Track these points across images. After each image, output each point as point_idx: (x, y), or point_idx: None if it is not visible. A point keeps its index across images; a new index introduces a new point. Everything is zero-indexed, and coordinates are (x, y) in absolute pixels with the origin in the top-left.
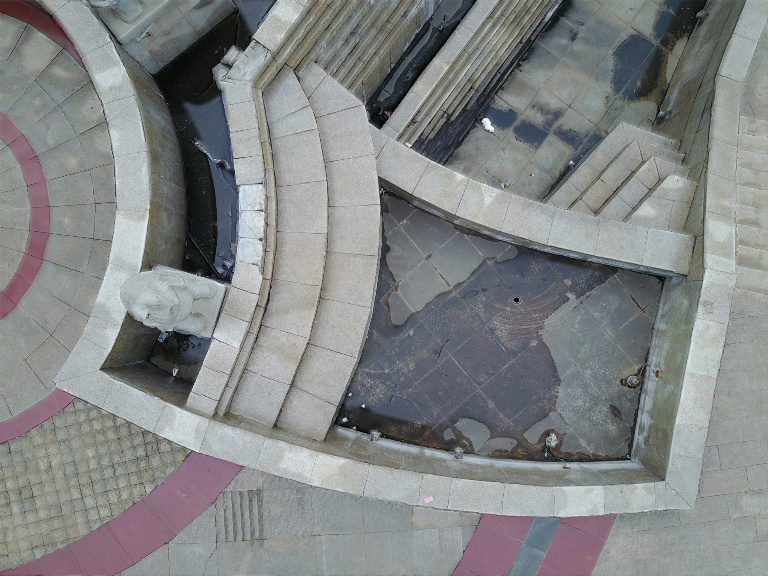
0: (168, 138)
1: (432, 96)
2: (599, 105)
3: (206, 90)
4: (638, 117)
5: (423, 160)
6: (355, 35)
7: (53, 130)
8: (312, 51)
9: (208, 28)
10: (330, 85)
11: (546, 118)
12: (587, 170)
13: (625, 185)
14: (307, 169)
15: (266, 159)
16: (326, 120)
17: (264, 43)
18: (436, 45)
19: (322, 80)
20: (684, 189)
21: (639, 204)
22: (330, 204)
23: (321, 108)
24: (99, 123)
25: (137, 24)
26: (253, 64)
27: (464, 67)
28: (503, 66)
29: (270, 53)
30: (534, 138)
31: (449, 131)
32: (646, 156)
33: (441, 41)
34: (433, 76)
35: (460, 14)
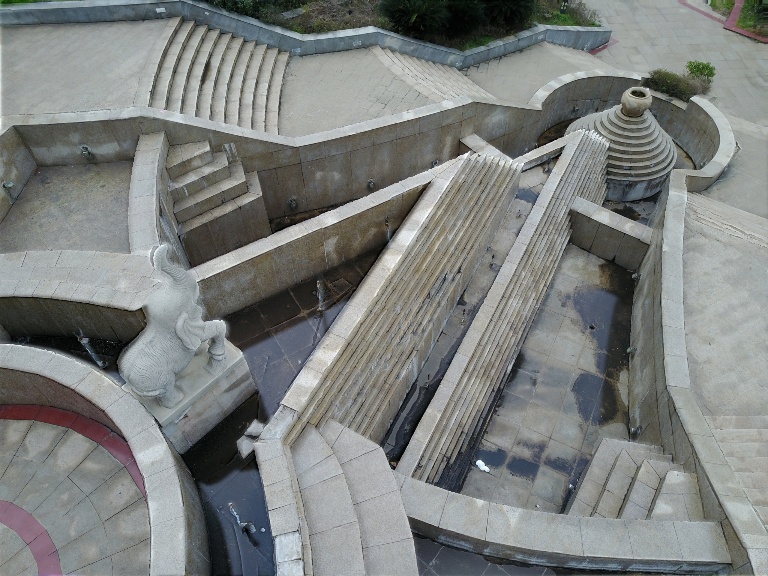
0: (197, 508)
1: (432, 441)
2: (576, 433)
3: (231, 460)
4: (613, 438)
5: (442, 492)
6: (362, 395)
7: (78, 521)
8: (329, 410)
9: (233, 408)
10: (348, 435)
11: (533, 451)
12: (590, 485)
13: (632, 489)
14: (338, 513)
15: (299, 508)
16: (349, 466)
17: (291, 406)
18: (425, 400)
19: (341, 432)
20: (687, 482)
21: (652, 505)
22: (363, 546)
23: (343, 456)
24: (126, 506)
25: (178, 408)
26: (282, 424)
27: (453, 414)
28: (484, 412)
29: (297, 413)
30: (528, 471)
31: (450, 474)
32: (638, 462)
33: (429, 396)
34: (430, 423)
35: (440, 374)
